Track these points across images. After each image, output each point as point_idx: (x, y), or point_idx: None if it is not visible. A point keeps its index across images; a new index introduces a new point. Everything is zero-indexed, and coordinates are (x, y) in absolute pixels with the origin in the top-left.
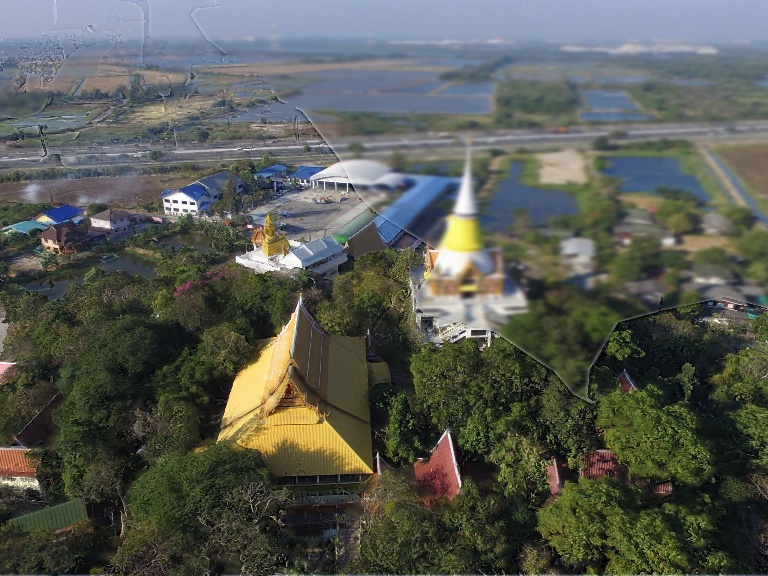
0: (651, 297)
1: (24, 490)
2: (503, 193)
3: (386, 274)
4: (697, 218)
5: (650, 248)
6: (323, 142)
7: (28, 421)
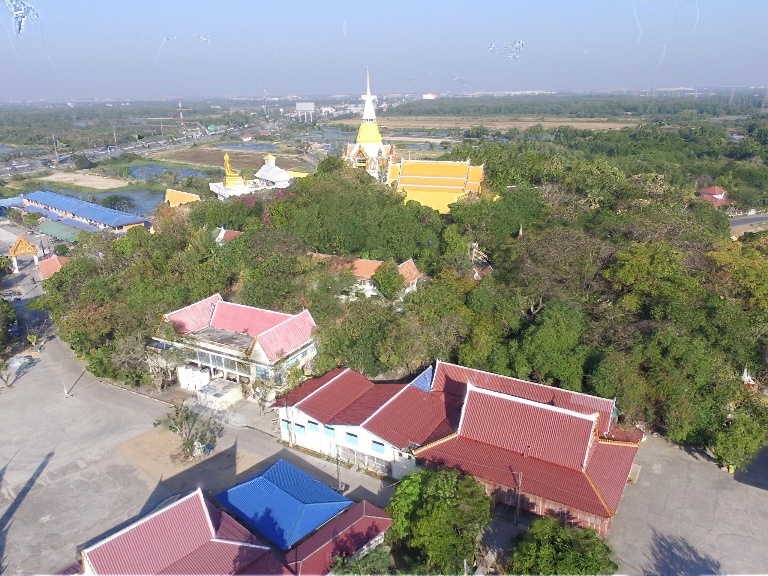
0: None
1: (412, 293)
2: None
3: None
4: None
5: None
6: None
7: None
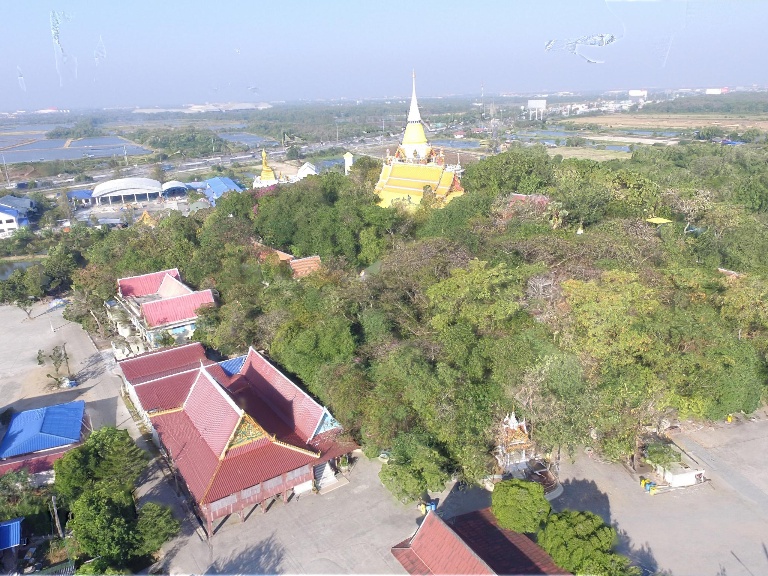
0: (683, 28)
1: None
2: (650, 2)
3: None
4: (690, 4)
5: (682, 14)
6: None
7: None
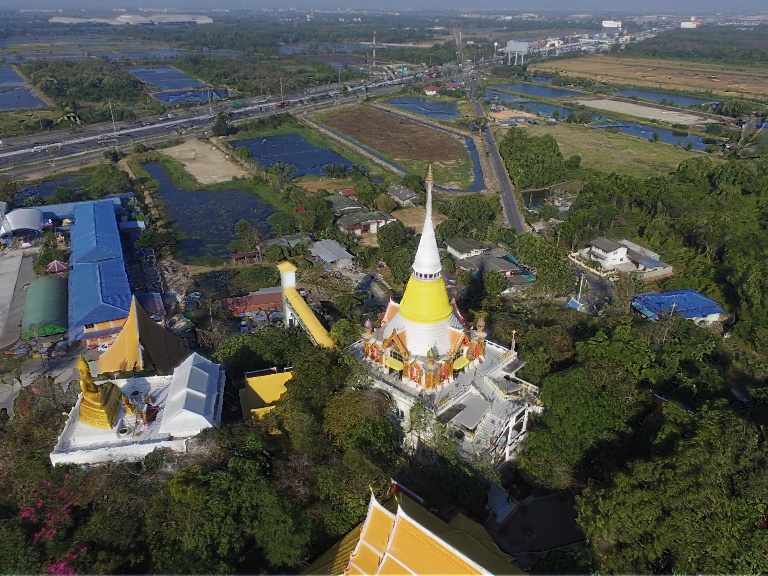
0: None
1: None
2: None
3: (340, 384)
4: None
5: None
6: None
7: None
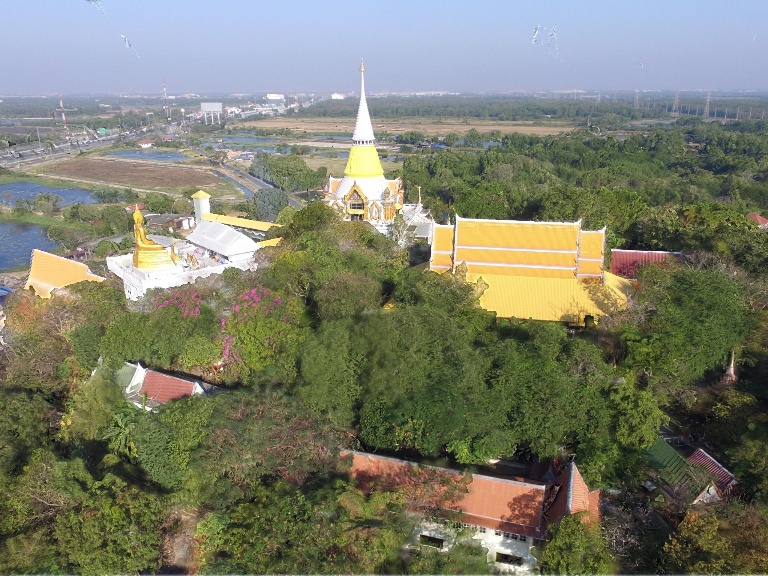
0: None
1: None
2: None
3: None
4: None
5: None
6: None
7: (384, 571)
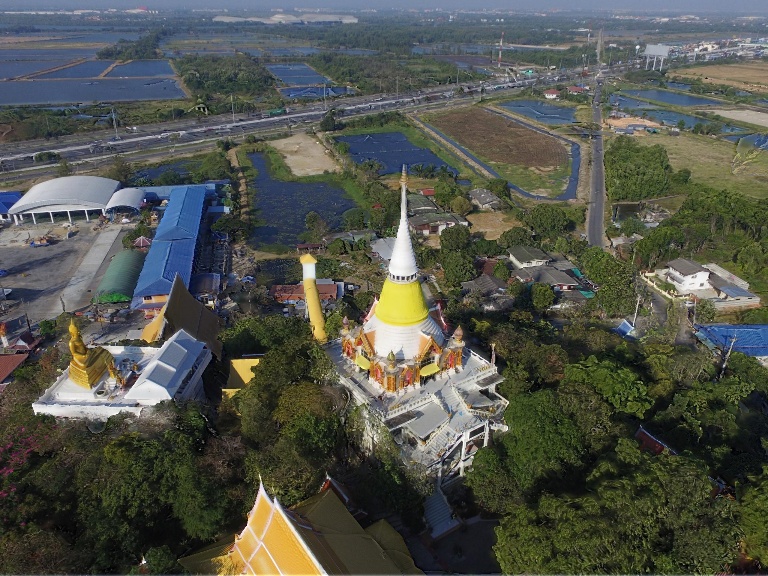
0: None
1: None
2: None
3: (304, 375)
4: None
5: None
6: (2, 157)
7: None
